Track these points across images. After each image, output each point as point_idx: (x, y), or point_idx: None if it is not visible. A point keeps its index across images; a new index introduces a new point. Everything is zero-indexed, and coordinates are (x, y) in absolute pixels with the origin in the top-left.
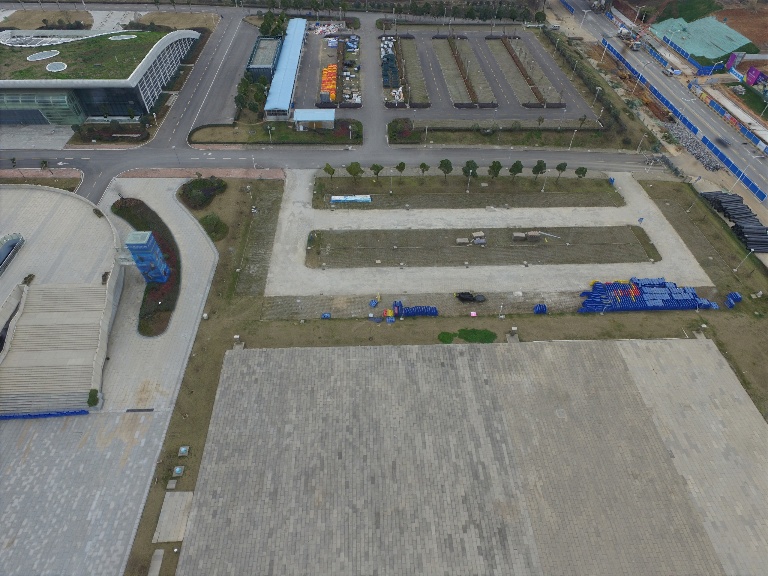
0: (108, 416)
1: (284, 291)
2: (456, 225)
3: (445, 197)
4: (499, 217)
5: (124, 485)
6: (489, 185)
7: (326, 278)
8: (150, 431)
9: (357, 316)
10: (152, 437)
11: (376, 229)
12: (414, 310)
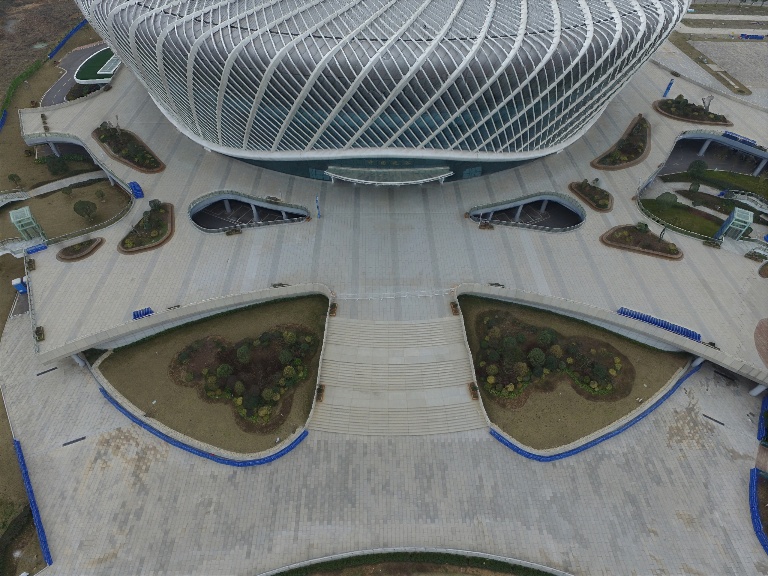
0: (659, 52)
1: (687, 32)
2: (744, 19)
3: (730, 12)
4: (763, 18)
5: (687, 63)
6: (750, 8)
7: (701, 30)
8: (681, 55)
9: (727, 38)
10: (683, 56)
11: (707, 19)
12: (754, 36)
